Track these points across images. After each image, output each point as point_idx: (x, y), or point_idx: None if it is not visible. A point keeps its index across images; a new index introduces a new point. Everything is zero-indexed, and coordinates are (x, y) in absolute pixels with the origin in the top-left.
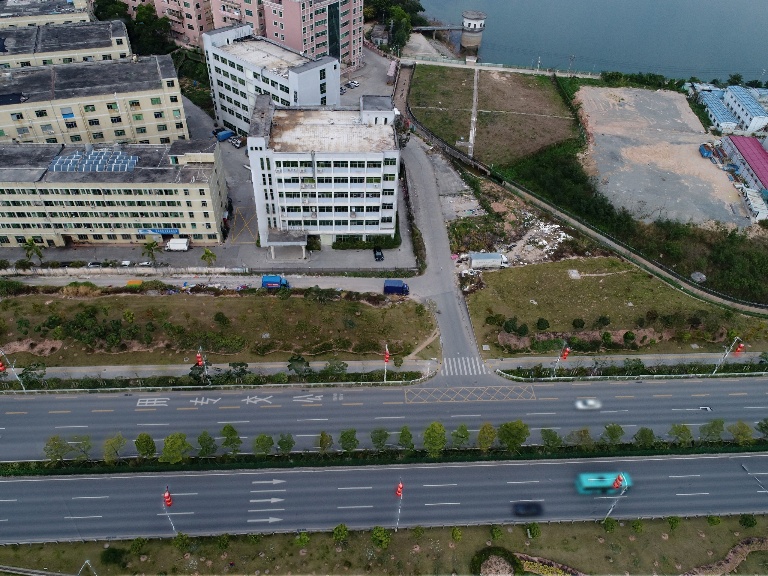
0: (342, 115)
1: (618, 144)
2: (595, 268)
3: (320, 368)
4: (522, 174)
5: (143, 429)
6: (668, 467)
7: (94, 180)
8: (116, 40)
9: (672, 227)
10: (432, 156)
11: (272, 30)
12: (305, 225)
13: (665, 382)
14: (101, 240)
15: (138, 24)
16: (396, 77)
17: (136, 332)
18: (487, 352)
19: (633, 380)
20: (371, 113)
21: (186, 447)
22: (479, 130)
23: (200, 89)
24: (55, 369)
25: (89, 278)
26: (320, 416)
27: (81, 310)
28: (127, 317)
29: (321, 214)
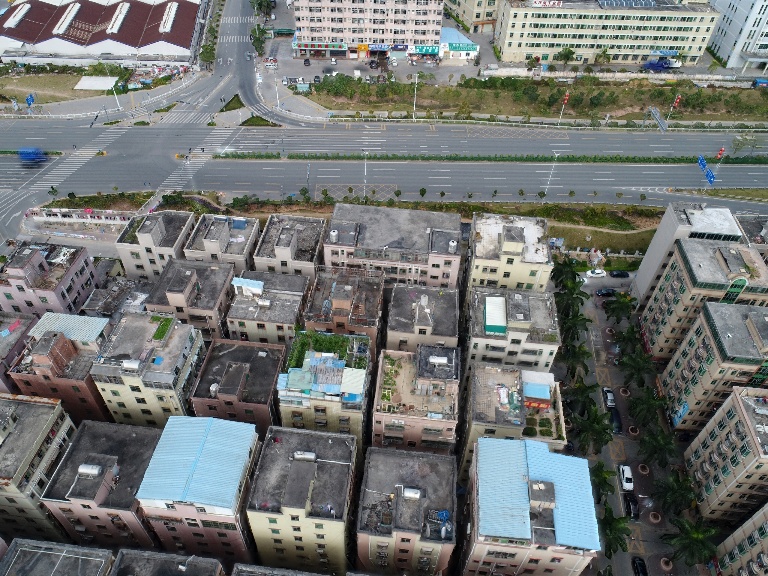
0: None
1: None
2: None
3: None
4: None
5: (755, 148)
6: None
7: None
8: None
9: None
10: None
11: None
12: None
13: None
14: (616, 61)
15: None
16: None
17: (716, 99)
18: None
19: None
20: None
21: None
22: None
23: None
24: None
25: None
26: None
27: None
28: (701, 92)
29: None
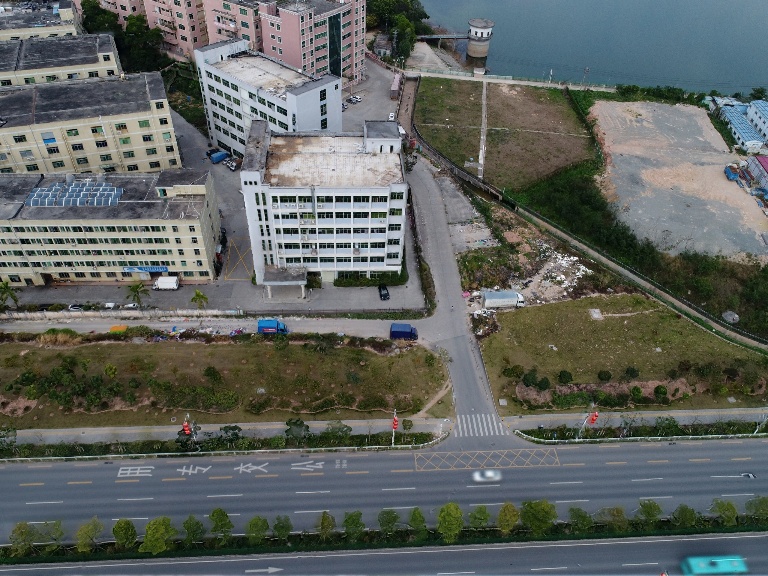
0: (344, 142)
1: (638, 165)
2: (618, 307)
3: (321, 429)
4: (536, 199)
5: (124, 505)
6: (710, 548)
7: (74, 216)
8: (103, 56)
9: (700, 260)
10: (440, 179)
11: (269, 43)
12: (304, 262)
13: (701, 443)
14: (84, 278)
15: (128, 36)
16: (400, 91)
17: (118, 390)
18: (504, 408)
19: (666, 441)
20: (376, 141)
21: (170, 534)
22: (489, 149)
23: (194, 105)
24: (28, 432)
25: (70, 322)
26: (321, 488)
27: (59, 362)
28: (108, 372)
29: (322, 251)
